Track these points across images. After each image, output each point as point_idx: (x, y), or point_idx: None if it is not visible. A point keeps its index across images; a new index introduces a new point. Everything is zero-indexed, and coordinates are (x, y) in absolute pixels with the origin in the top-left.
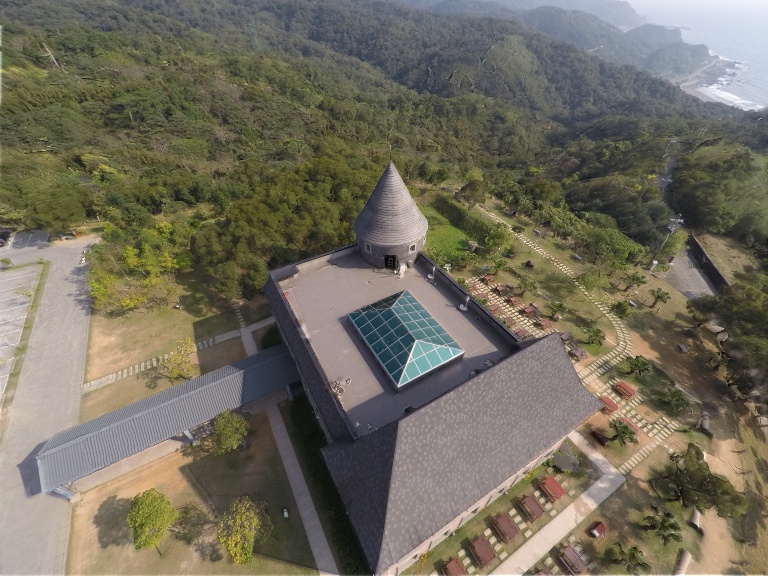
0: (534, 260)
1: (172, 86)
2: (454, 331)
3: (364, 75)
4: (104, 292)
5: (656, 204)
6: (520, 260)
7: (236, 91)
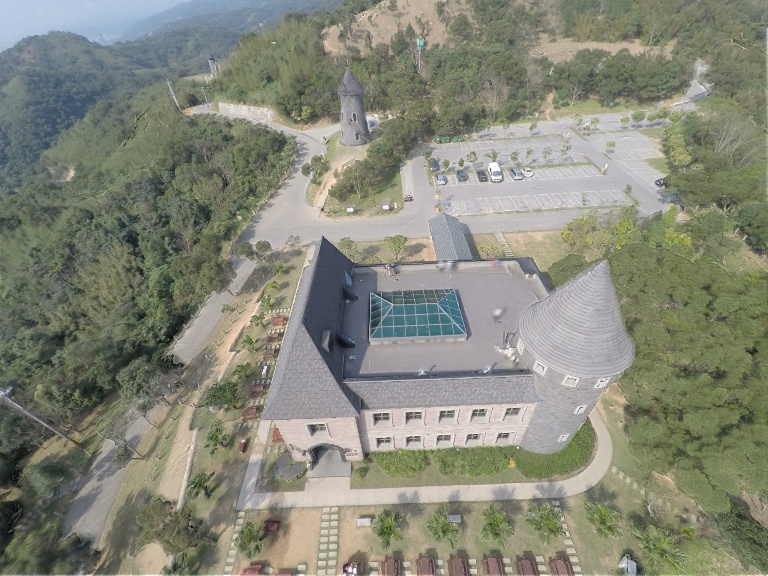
0: None
1: None
2: (399, 353)
3: None
4: (582, 224)
5: None
6: None
7: None
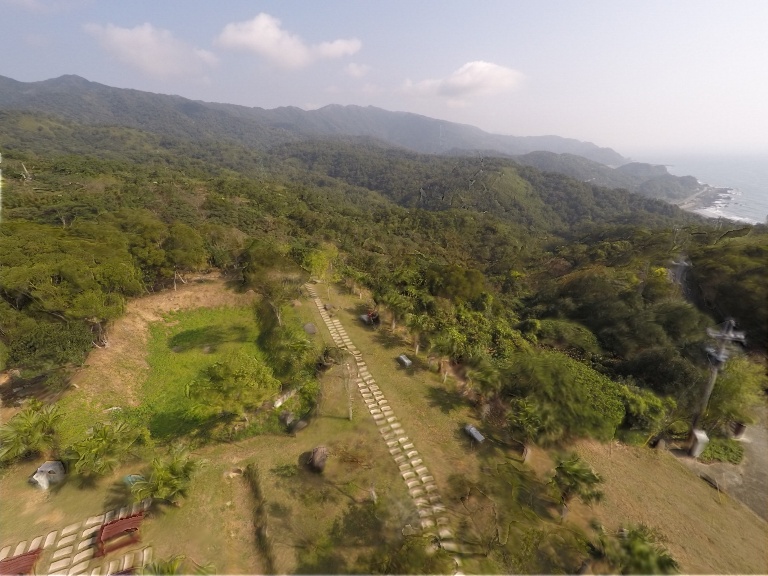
0: (346, 444)
1: (127, 196)
2: None
3: (358, 196)
4: None
5: (671, 305)
6: (307, 443)
7: (198, 201)
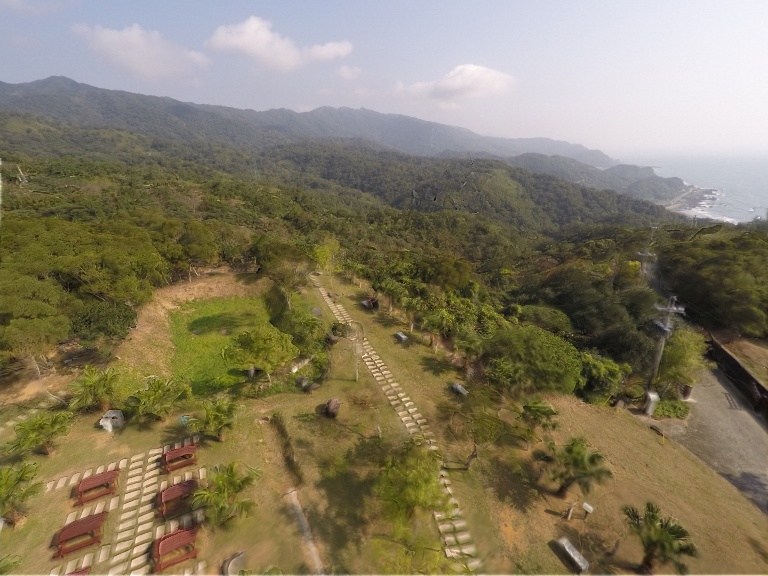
0: None
1: (124, 198)
2: None
3: (352, 198)
4: None
5: (636, 290)
6: (321, 398)
7: (194, 203)
